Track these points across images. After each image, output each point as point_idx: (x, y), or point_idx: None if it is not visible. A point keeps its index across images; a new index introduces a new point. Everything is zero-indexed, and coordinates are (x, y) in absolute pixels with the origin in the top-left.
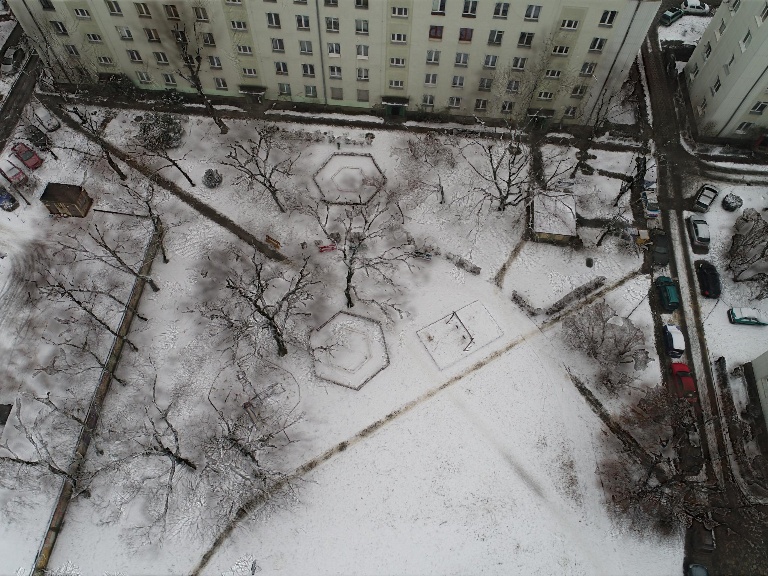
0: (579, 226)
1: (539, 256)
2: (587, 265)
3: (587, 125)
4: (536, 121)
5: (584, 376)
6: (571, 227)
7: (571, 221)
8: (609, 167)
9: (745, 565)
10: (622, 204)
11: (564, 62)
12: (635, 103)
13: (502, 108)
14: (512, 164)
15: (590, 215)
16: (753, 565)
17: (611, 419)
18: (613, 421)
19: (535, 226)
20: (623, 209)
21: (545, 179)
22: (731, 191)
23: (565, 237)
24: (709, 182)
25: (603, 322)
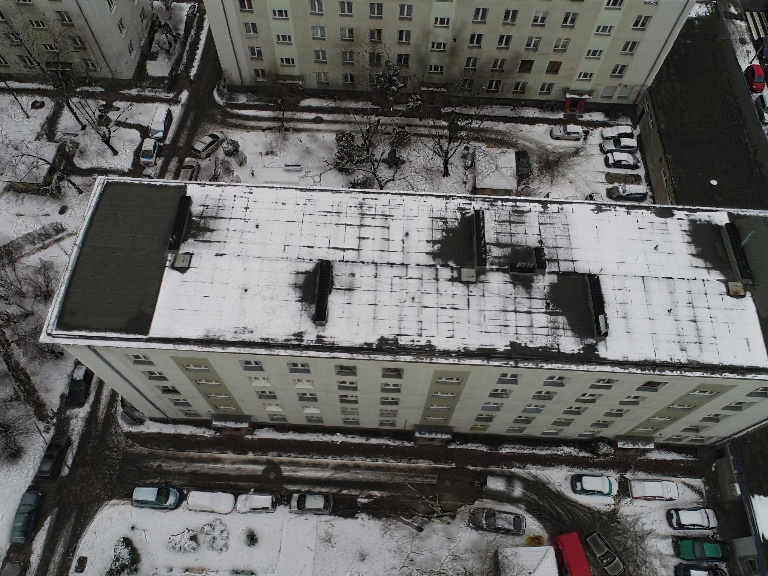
0: (70, 175)
1: (13, 205)
2: (59, 212)
3: (115, 78)
4: (62, 75)
5: (4, 318)
6: (38, 175)
7: (41, 169)
8: (128, 118)
9: (89, 490)
10: (124, 153)
11: (35, 11)
12: (174, 55)
13: (24, 63)
14: (27, 118)
15: (84, 164)
16: (97, 489)
17: (13, 358)
18: (15, 360)
19: (3, 175)
20: (123, 158)
21: (56, 131)
22: (241, 137)
23: (37, 185)
24: (225, 129)
25: (11, 263)
